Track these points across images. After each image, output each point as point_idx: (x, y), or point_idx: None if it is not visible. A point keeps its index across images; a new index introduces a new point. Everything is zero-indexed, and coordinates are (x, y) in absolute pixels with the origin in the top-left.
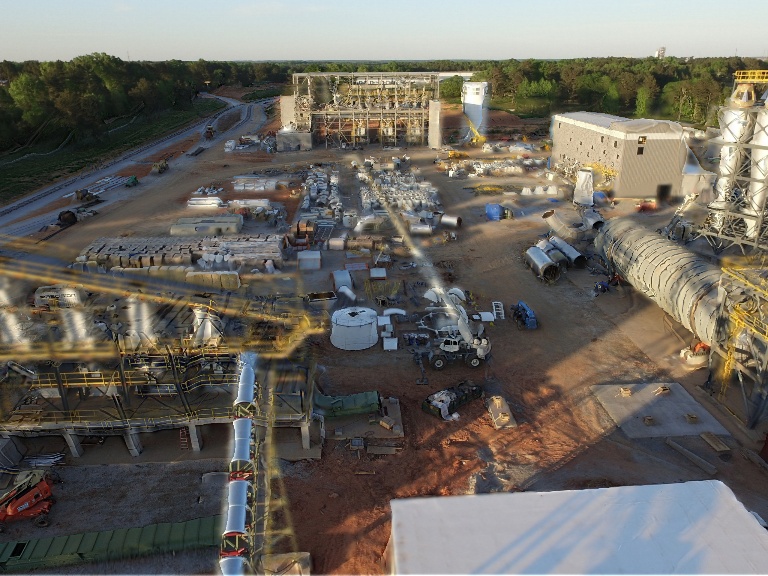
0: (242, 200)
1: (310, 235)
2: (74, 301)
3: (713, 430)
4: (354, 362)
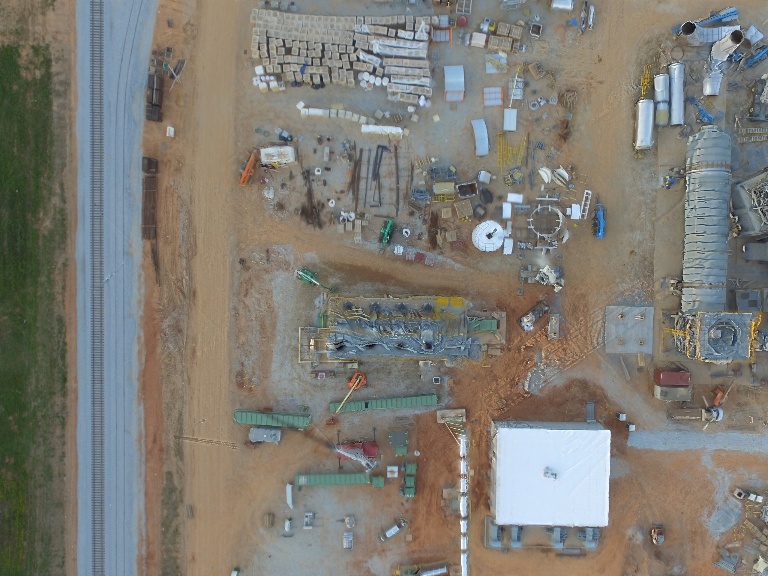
0: None
1: (452, 3)
2: (288, 160)
3: (646, 351)
4: (485, 266)
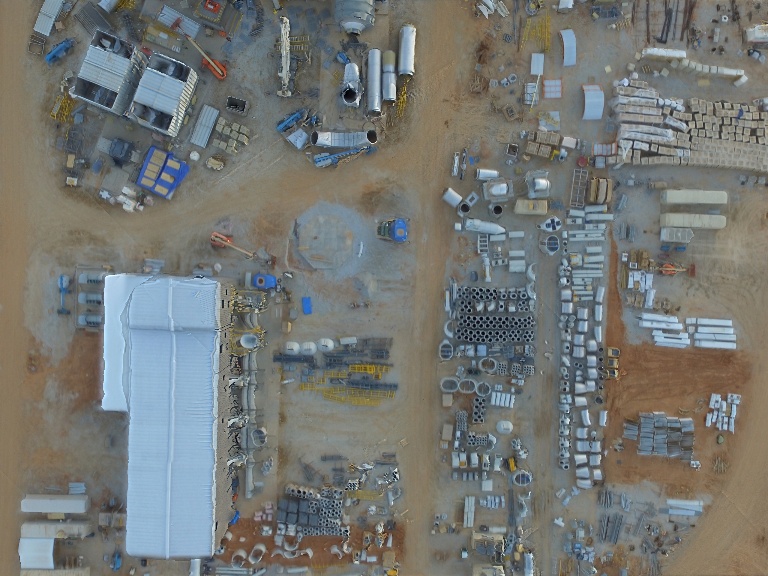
0: (674, 323)
1: None
2: None
3: None
4: None
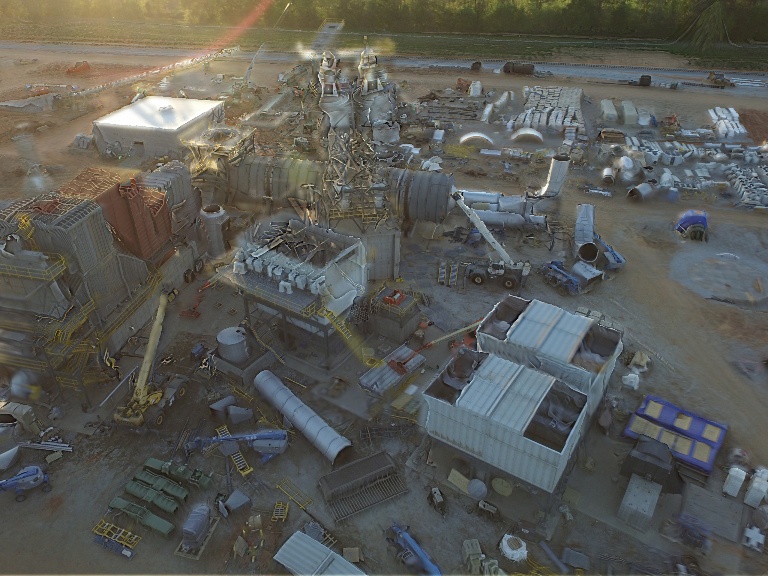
0: (725, 121)
1: None
2: None
3: None
4: None
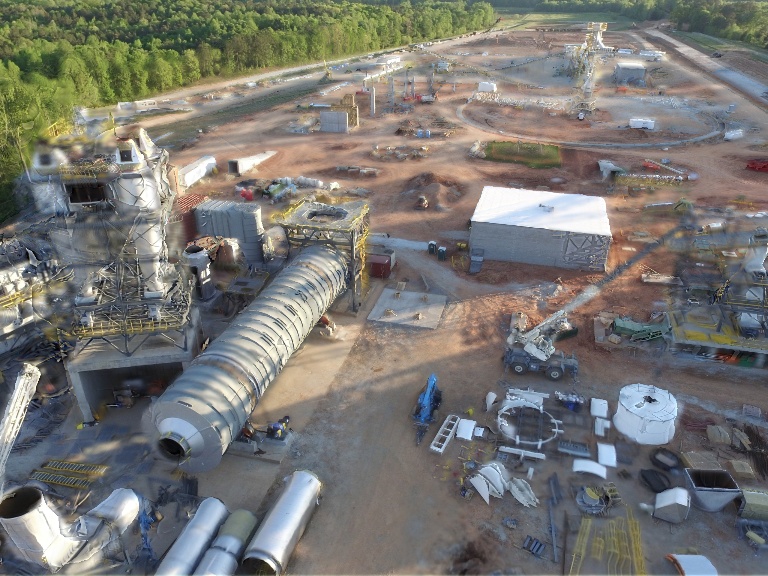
0: None
1: None
2: None
3: None
4: None
